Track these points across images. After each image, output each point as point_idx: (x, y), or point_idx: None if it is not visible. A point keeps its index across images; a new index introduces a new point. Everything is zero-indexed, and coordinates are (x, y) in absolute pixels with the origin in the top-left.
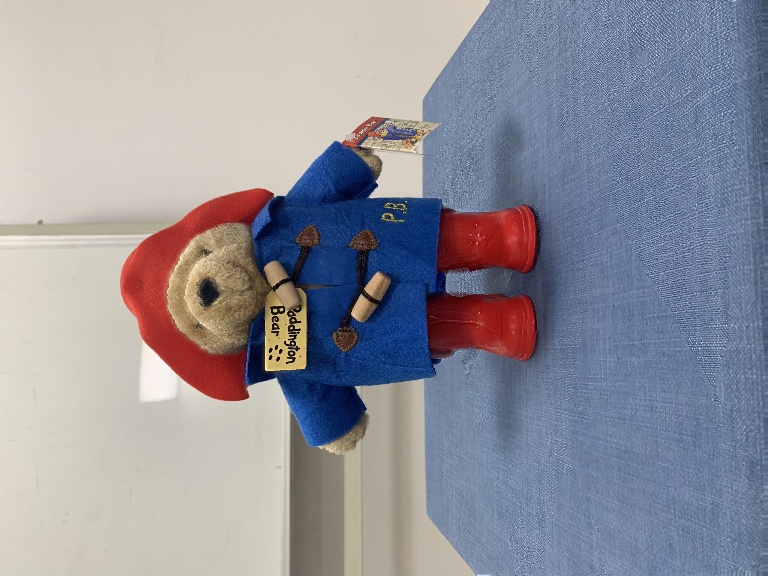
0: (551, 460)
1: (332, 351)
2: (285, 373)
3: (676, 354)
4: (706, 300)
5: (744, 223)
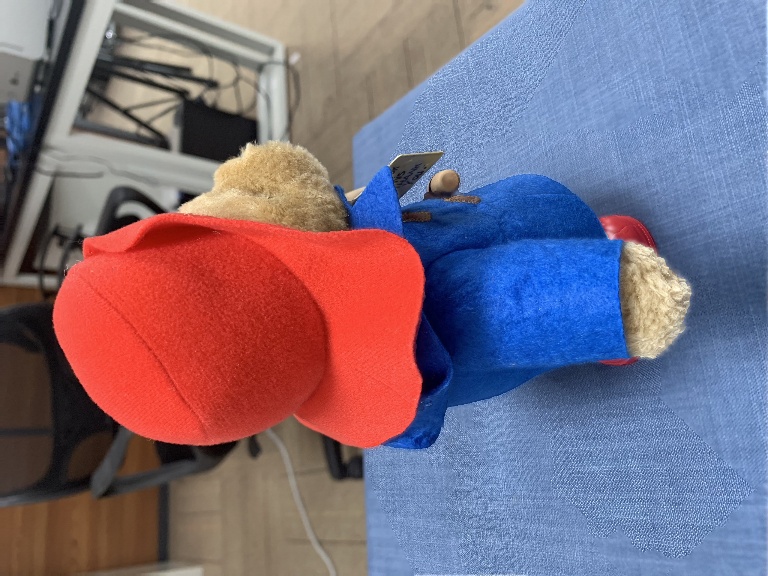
0: (760, 133)
1: (464, 206)
2: (441, 247)
3: (594, 7)
4: (560, 2)
5: (525, 4)
